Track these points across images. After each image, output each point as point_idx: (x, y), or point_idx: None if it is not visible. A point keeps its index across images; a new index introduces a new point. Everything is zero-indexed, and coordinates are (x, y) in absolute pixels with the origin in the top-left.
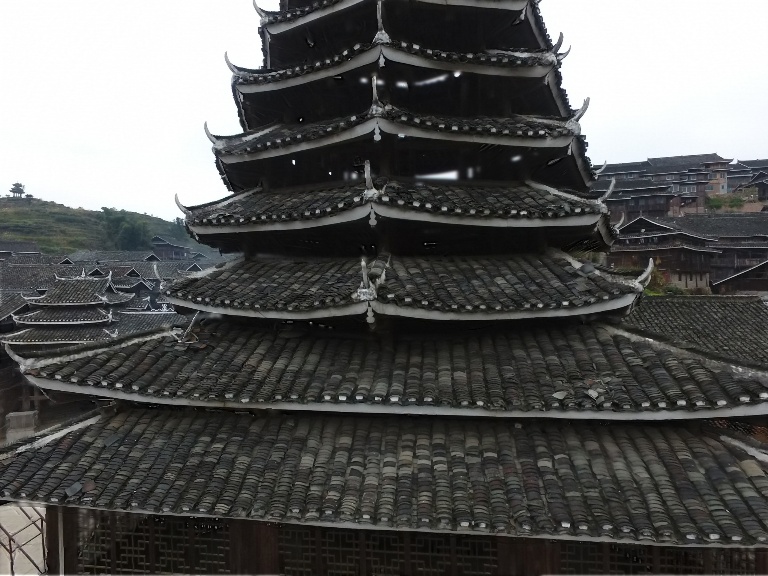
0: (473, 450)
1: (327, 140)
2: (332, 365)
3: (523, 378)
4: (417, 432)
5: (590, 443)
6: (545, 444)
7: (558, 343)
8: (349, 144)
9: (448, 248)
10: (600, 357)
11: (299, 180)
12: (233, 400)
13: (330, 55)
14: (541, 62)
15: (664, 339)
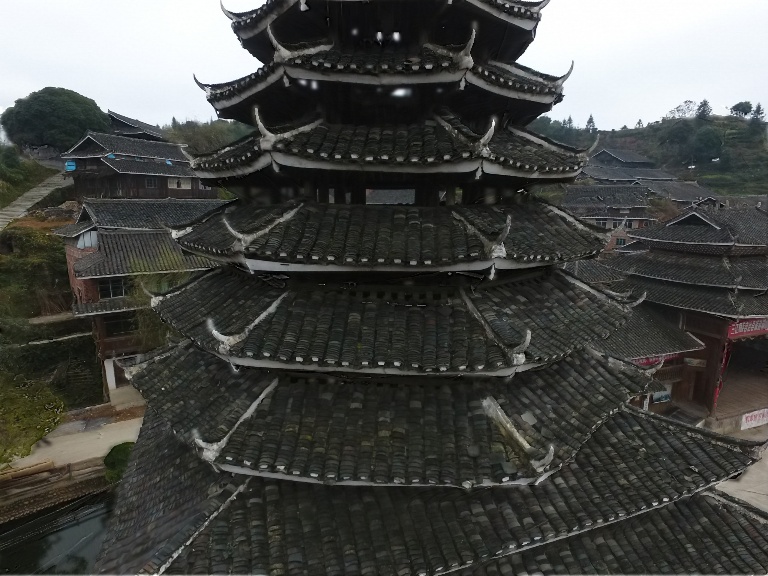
0: None
1: None
2: None
3: None
4: None
5: None
6: None
7: None
8: None
9: None
10: None
11: None
12: None
13: None
14: None
15: None
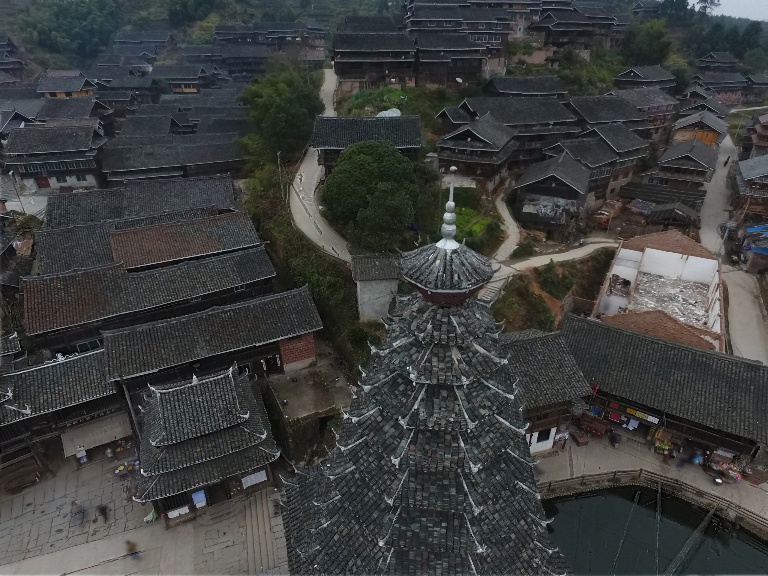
0: None
1: None
2: None
3: None
4: None
5: None
6: None
7: None
8: None
9: None
10: None
11: None
12: None
13: None
14: (534, 497)
15: None
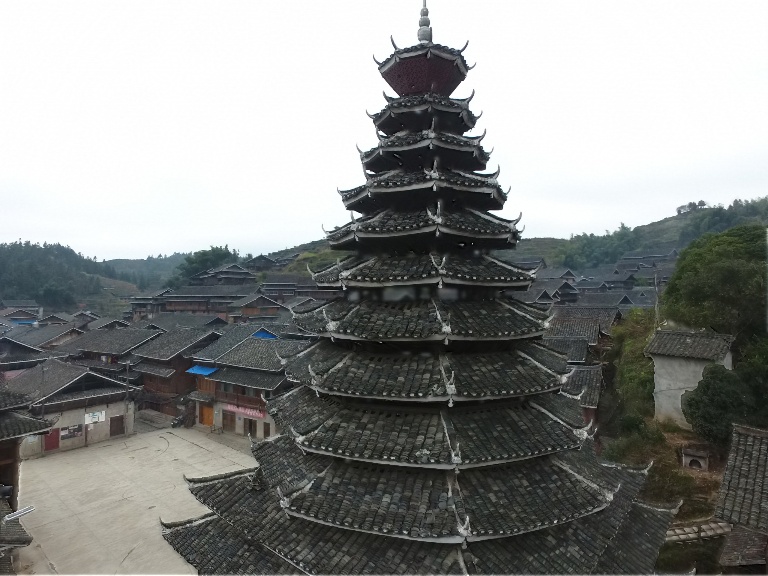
0: None
1: None
2: None
3: None
4: None
5: None
6: None
7: (419, 553)
8: None
9: None
10: None
11: None
12: None
13: None
14: (440, 330)
15: None
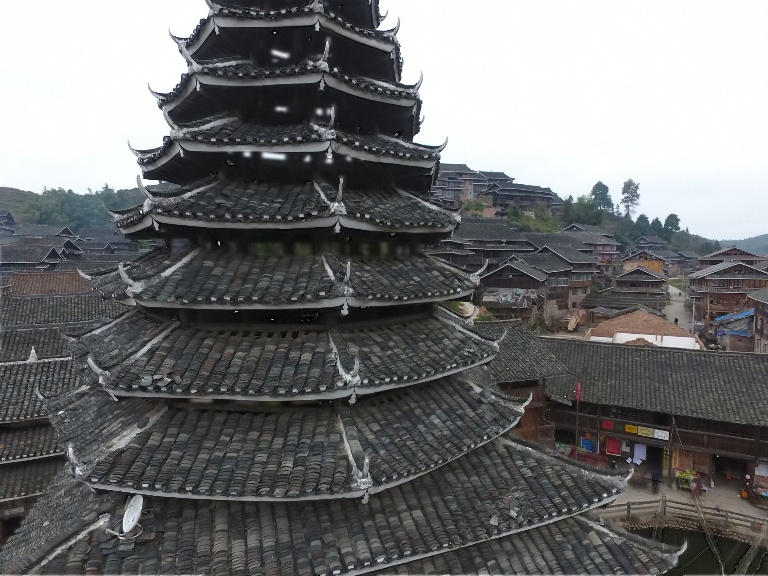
0: None
1: (288, 306)
2: (303, 526)
3: (464, 507)
4: (383, 569)
5: (506, 544)
6: (479, 554)
7: (472, 460)
8: None
9: None
10: (505, 472)
11: (231, 320)
12: None
13: (250, 177)
14: (450, 220)
15: (539, 449)
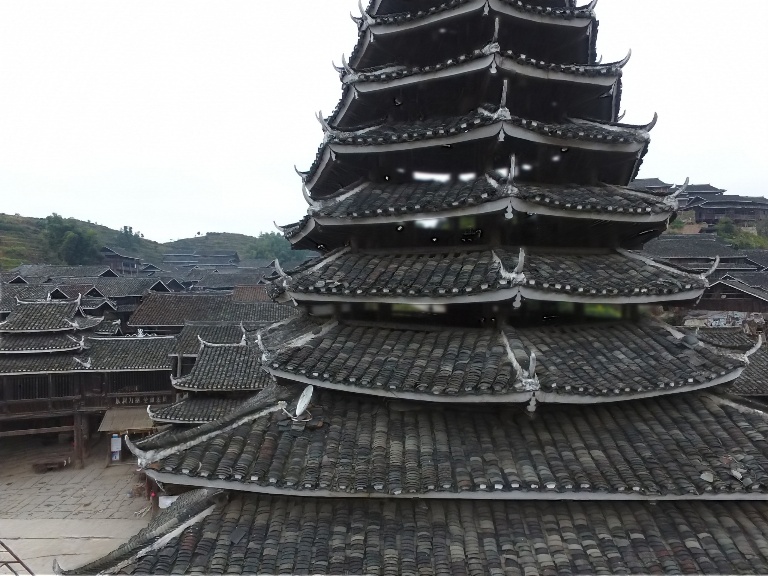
0: (619, 531)
1: (450, 213)
2: (462, 444)
3: (661, 457)
4: (555, 512)
5: (726, 519)
6: (685, 522)
7: (673, 414)
8: (469, 217)
9: (562, 320)
10: (721, 431)
11: (396, 243)
12: (383, 491)
13: (416, 115)
14: (635, 138)
15: None
